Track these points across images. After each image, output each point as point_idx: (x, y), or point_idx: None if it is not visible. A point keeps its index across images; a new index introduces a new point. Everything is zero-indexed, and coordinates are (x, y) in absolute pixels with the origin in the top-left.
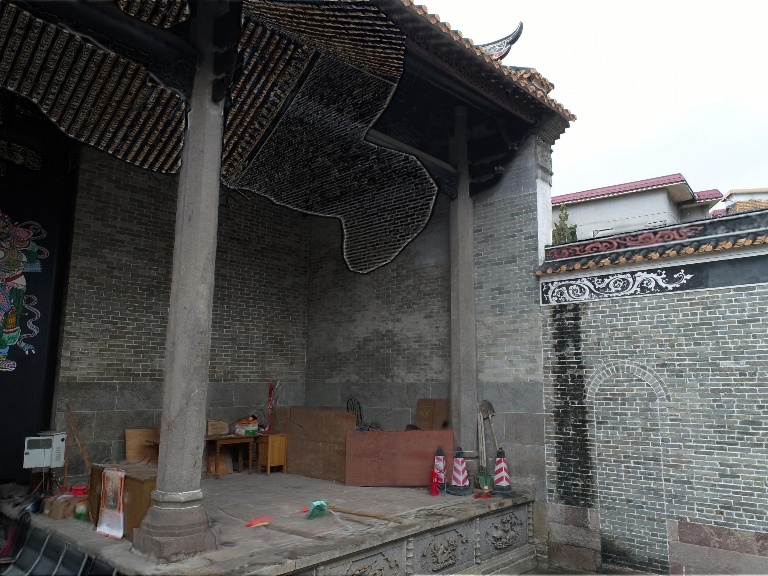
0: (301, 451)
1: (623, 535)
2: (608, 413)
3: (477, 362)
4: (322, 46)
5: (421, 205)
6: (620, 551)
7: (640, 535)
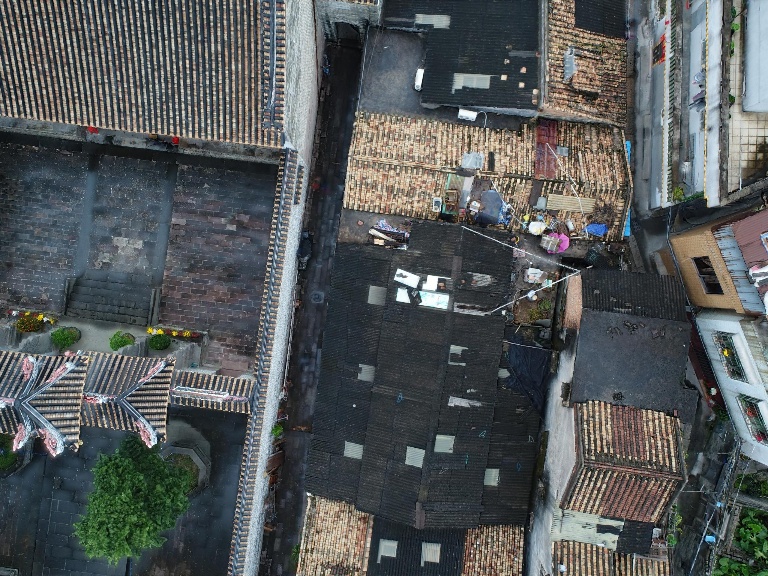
0: None
1: None
2: None
3: None
4: (224, 3)
5: (296, 67)
6: None
7: None
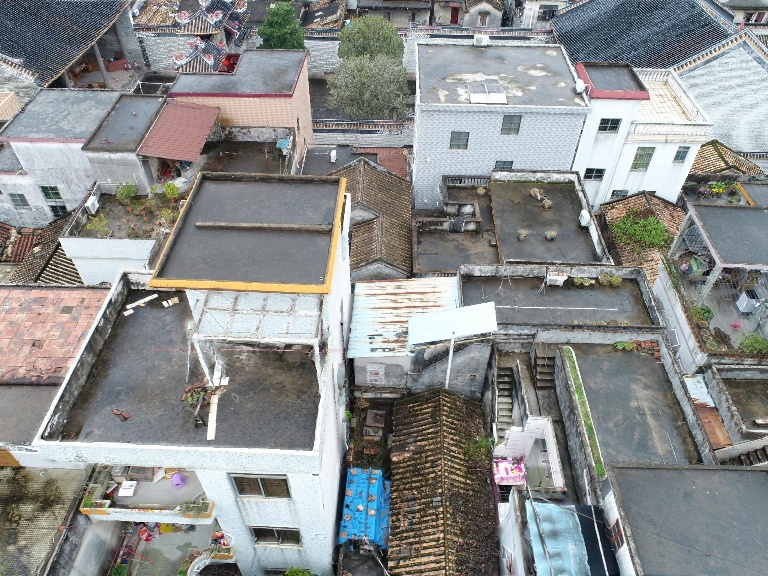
0: (96, 67)
1: (156, 70)
2: (150, 54)
3: (126, 45)
4: None
5: None
6: (156, 72)
7: (158, 70)
